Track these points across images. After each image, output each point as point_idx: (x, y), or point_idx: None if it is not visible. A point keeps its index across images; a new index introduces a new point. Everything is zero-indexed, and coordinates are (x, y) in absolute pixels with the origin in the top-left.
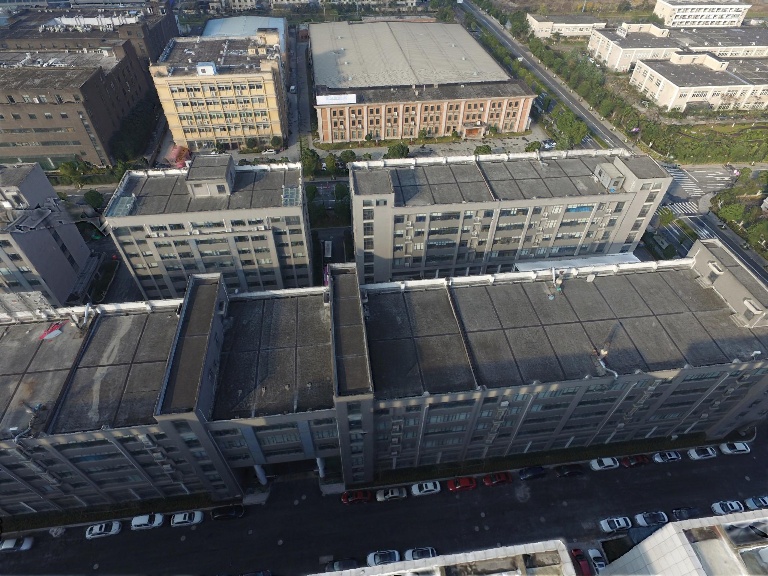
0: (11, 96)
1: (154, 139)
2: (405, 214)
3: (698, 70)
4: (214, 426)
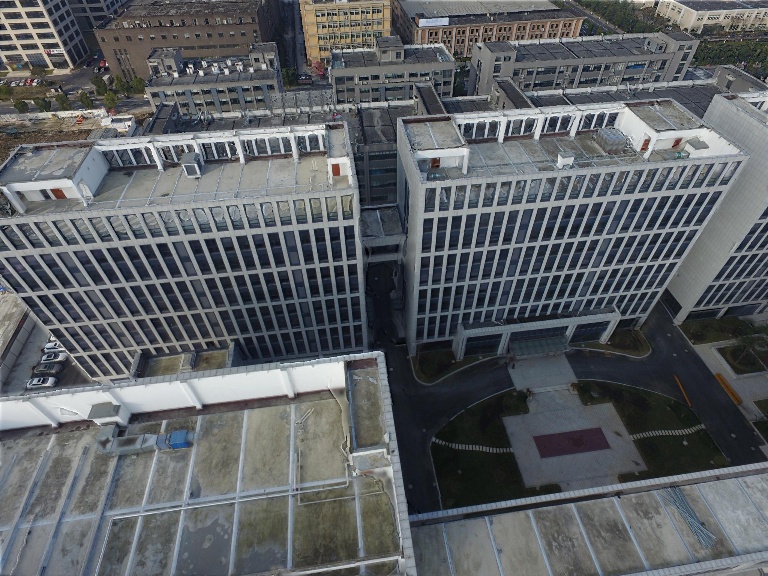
0: (207, 19)
1: (289, 61)
2: (521, 68)
3: (712, 1)
4: None
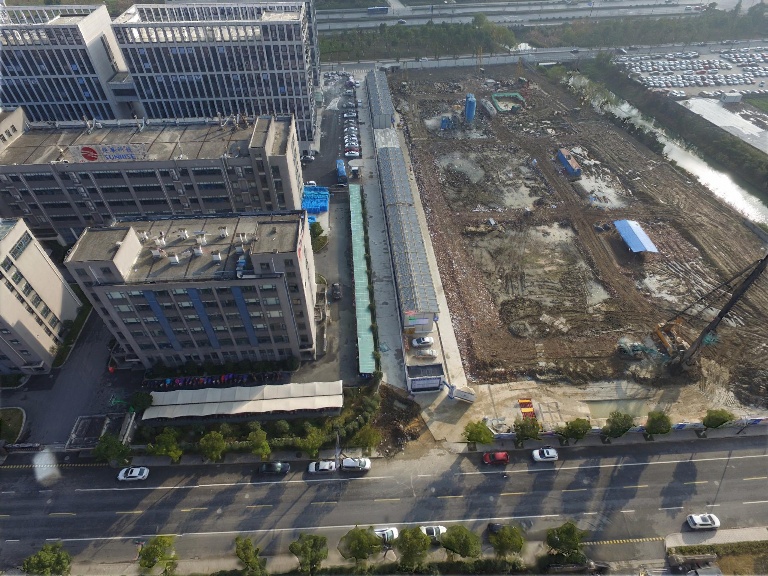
0: None
1: None
2: None
3: None
4: None
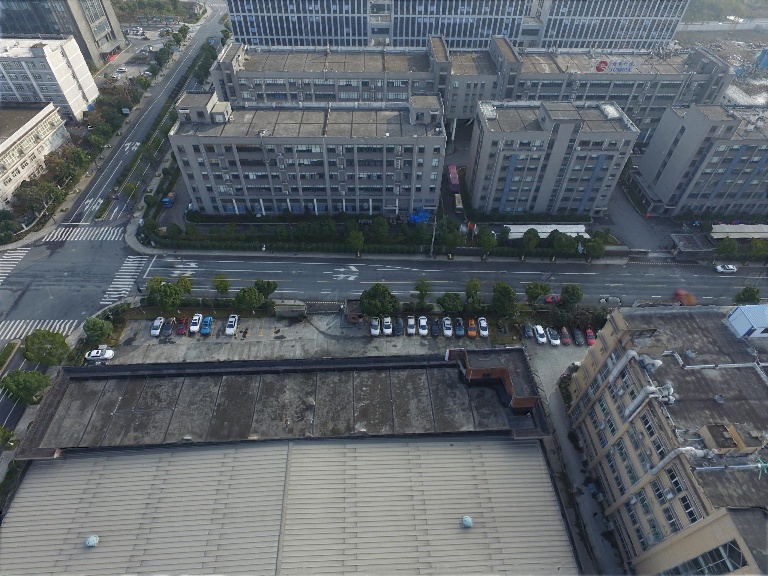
0: None
1: None
2: None
3: None
4: (487, 51)
